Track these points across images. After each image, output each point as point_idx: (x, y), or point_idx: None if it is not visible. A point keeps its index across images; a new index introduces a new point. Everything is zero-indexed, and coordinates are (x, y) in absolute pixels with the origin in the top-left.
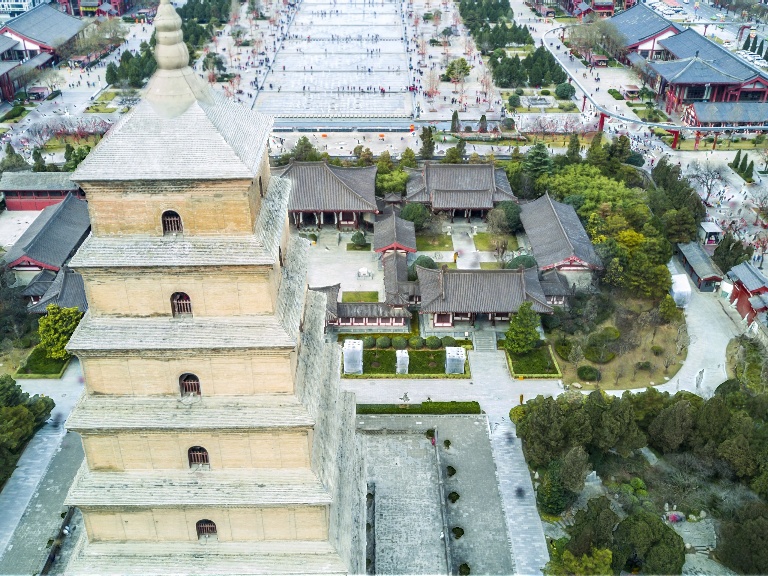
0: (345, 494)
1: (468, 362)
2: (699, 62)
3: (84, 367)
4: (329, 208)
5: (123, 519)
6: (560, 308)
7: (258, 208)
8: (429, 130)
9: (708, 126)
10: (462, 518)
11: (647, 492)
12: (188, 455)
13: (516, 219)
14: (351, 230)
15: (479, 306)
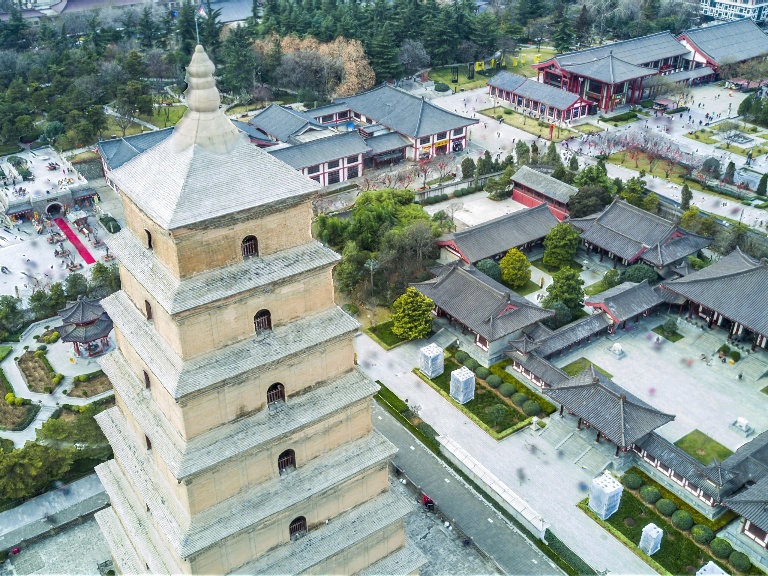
0: (270, 575)
1: None
2: None
3: (114, 324)
4: (764, 332)
5: None
6: None
7: (226, 262)
8: None
9: None
10: None
11: None
12: (147, 438)
13: None
14: None
15: None
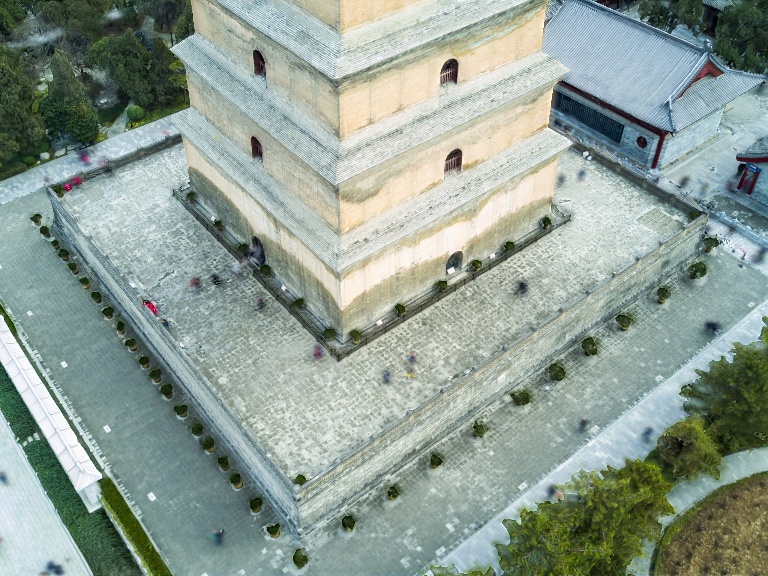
0: None
1: None
2: None
3: None
4: None
5: None
6: None
7: None
8: None
9: None
10: None
11: None
12: None
13: None
14: None
15: None
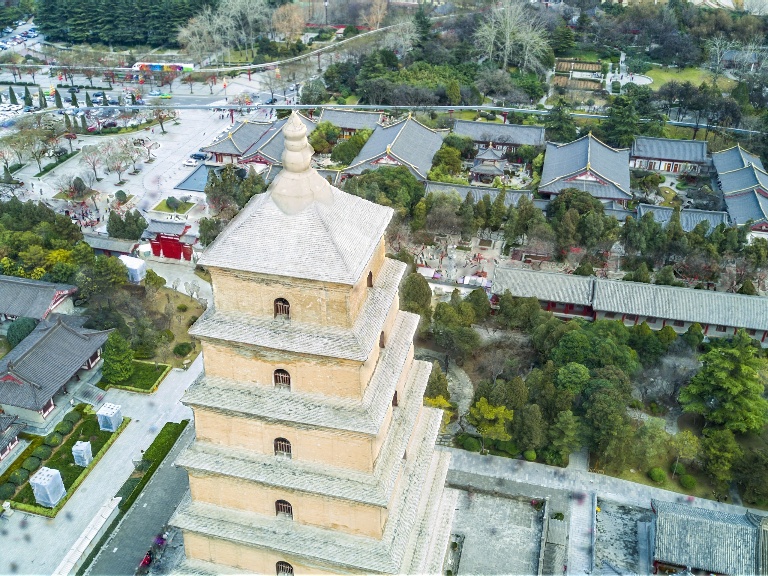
0: None
1: None
2: None
3: None
4: None
5: None
6: None
7: None
8: None
9: None
10: None
11: None
12: None
13: None
14: None
15: (68, 370)
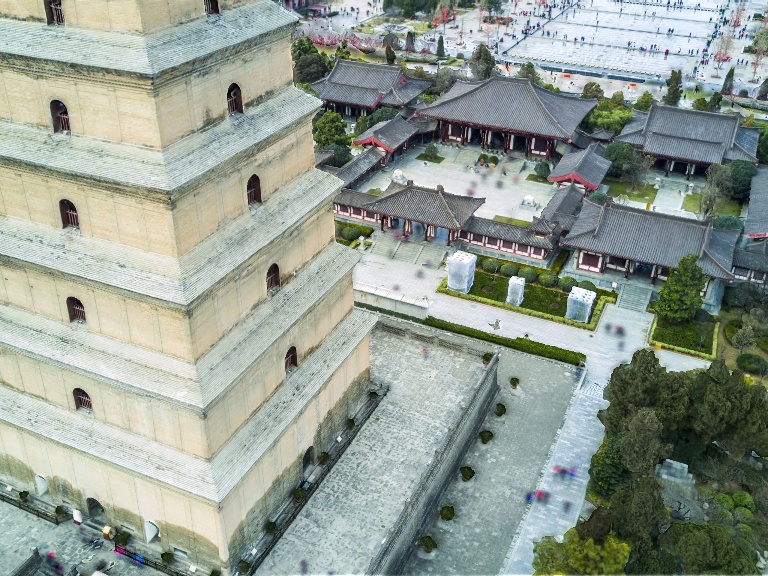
0: (263, 335)
1: (600, 314)
2: None
3: None
4: (516, 128)
5: (3, 275)
6: (756, 287)
7: None
8: (678, 74)
9: None
10: (485, 462)
11: (752, 513)
12: (61, 211)
13: (746, 182)
14: (539, 160)
15: (636, 252)
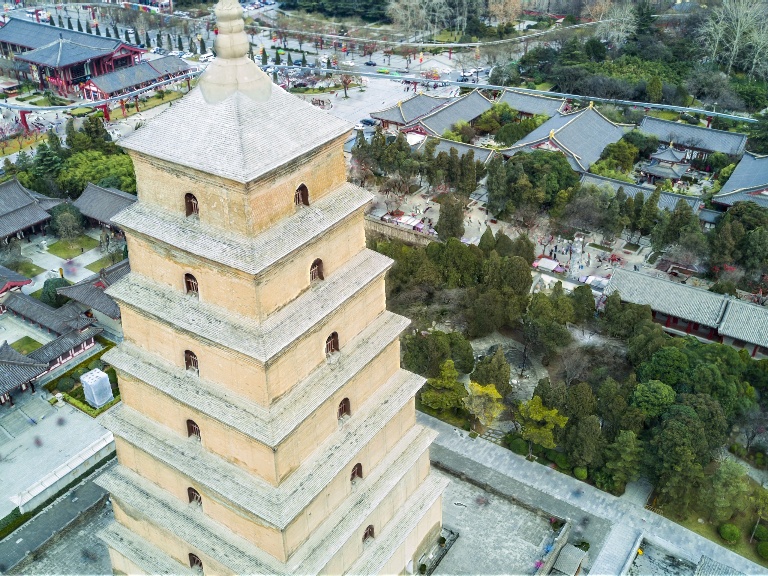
0: None
1: None
2: (67, 43)
3: (267, 377)
4: None
5: (308, 514)
6: None
7: None
8: None
9: (126, 93)
10: None
11: None
12: None
13: (80, 217)
14: None
15: None
